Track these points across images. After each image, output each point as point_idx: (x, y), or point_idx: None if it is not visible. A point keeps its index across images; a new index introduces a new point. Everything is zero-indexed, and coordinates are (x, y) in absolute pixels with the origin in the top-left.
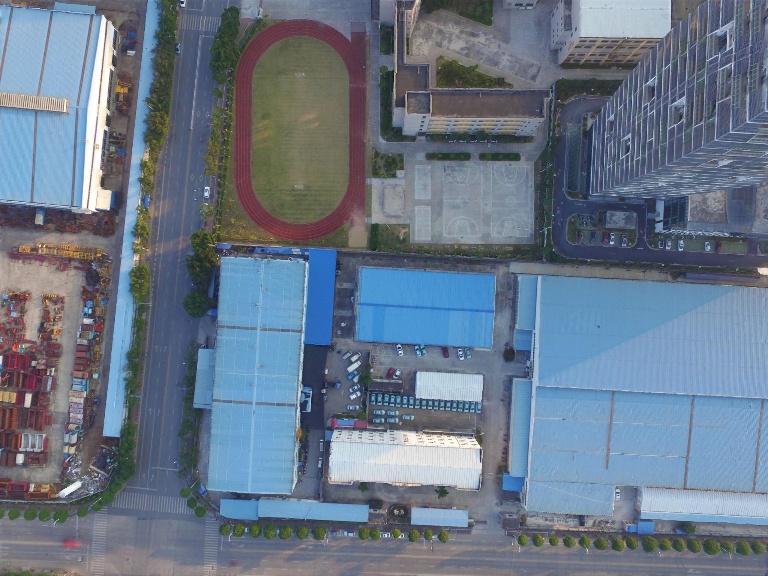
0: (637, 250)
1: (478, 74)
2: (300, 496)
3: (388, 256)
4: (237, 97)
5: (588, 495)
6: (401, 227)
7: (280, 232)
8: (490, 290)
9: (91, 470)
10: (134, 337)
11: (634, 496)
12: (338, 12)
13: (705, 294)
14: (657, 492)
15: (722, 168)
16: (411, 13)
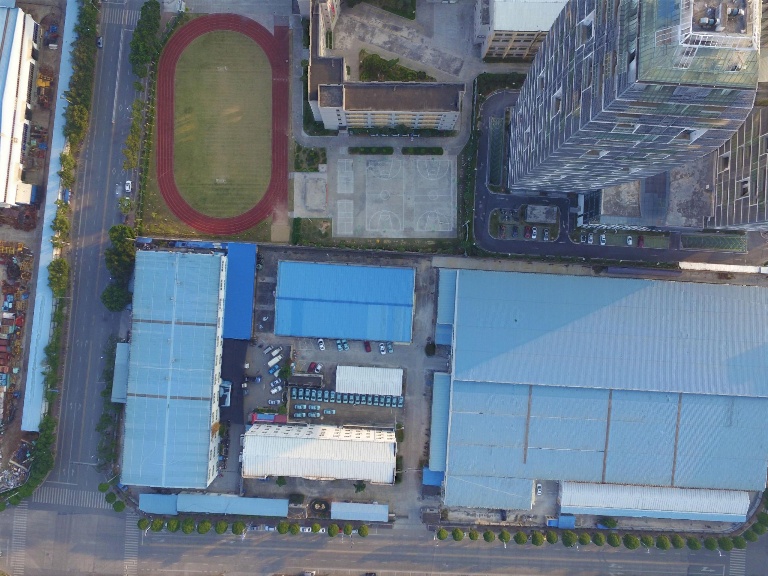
0: (559, 244)
1: (401, 68)
2: (221, 491)
3: (310, 250)
4: (159, 91)
5: (506, 489)
6: (322, 221)
7: (202, 226)
8: (409, 284)
9: (11, 465)
10: (54, 331)
11: (556, 491)
12: (261, 6)
13: (623, 288)
14: (577, 486)
15: (605, 159)
16: (326, 6)
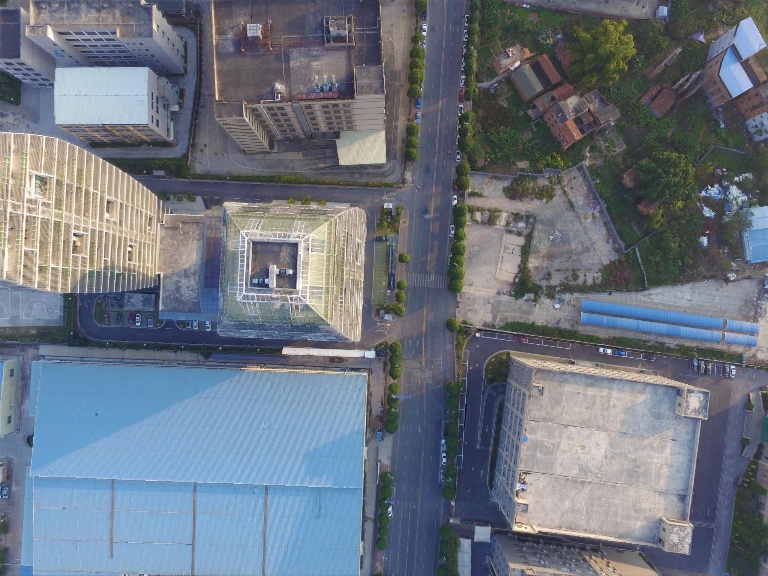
0: (166, 330)
1: None
2: None
3: None
4: None
5: None
6: None
7: None
8: None
9: None
10: None
11: None
12: None
13: (209, 379)
14: None
15: None
16: None
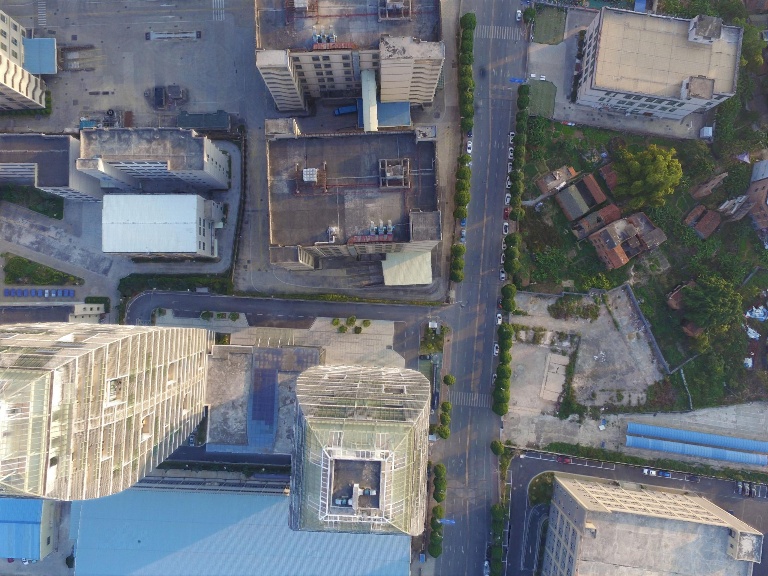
0: None
1: (47, 269)
2: None
3: None
4: None
5: None
6: None
7: None
8: None
9: None
10: None
11: None
12: None
13: (253, 505)
14: None
15: None
16: None
